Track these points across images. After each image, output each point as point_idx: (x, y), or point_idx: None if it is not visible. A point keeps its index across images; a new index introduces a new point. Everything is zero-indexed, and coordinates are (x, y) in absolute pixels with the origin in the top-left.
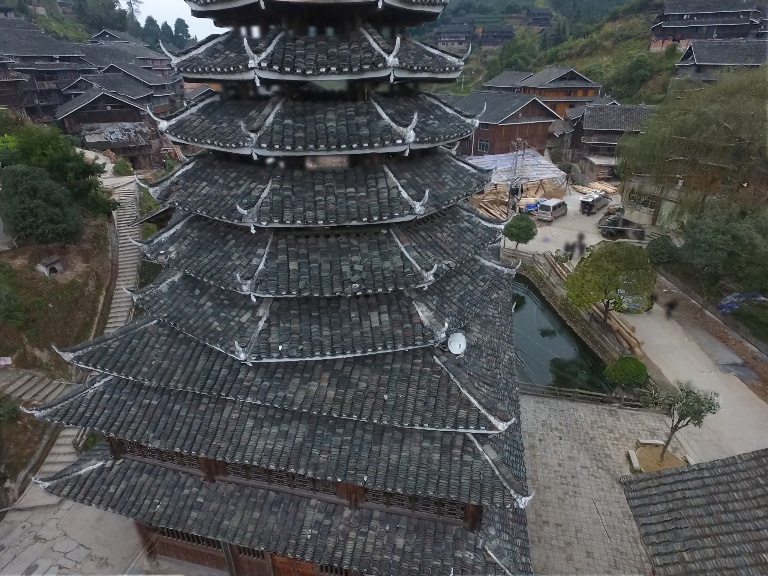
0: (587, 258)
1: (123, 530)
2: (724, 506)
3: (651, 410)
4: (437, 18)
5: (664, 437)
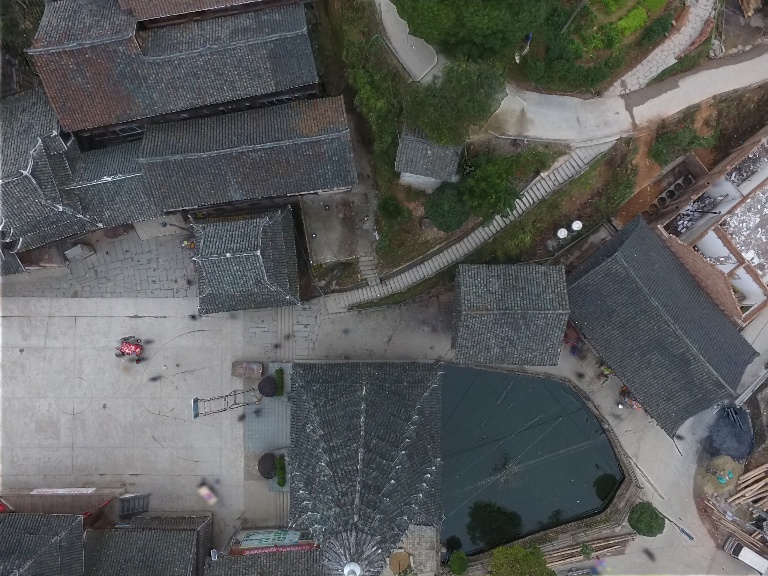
0: (521, 570)
1: (326, 346)
2: (315, 575)
3: (437, 567)
4: None
5: (419, 568)
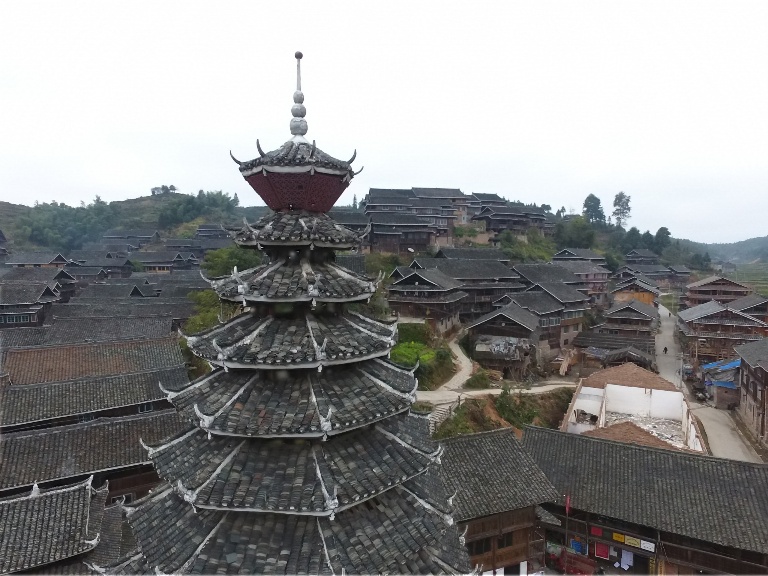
0: None
1: None
2: None
3: None
4: (322, 440)
5: None
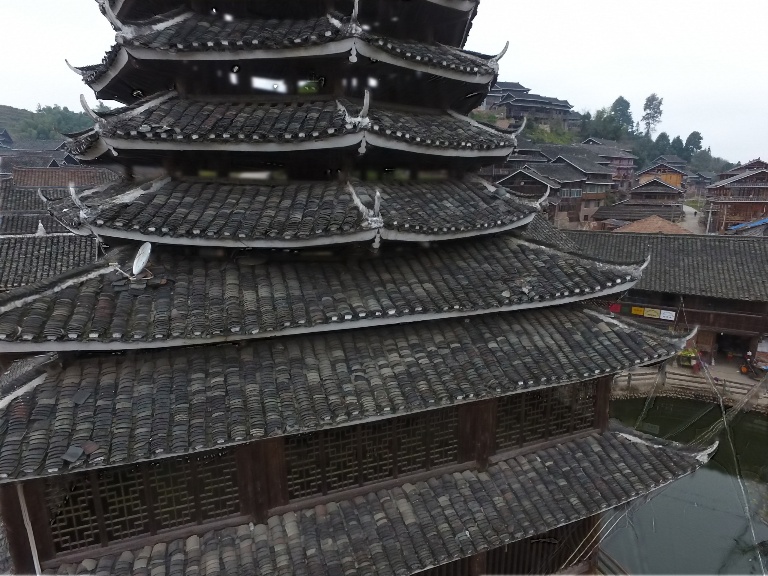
0: None
1: None
2: None
3: None
4: None
5: None
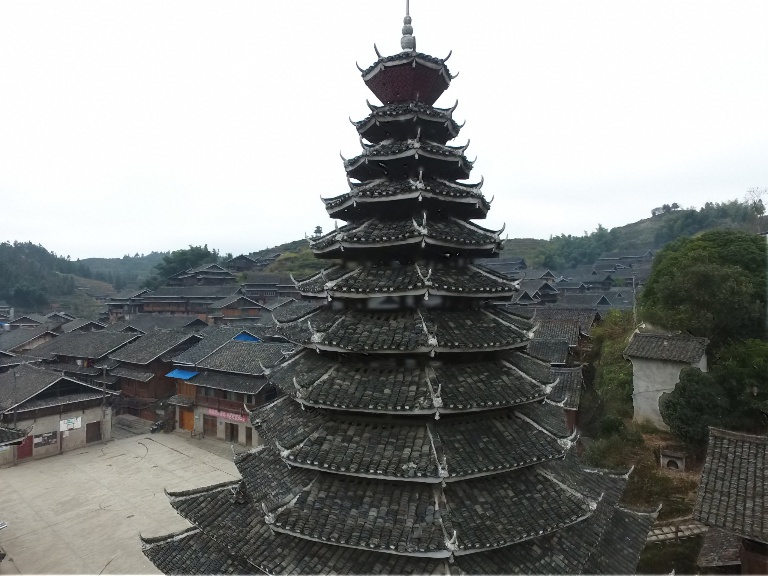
0: None
1: None
2: None
3: None
4: (343, 251)
5: None
